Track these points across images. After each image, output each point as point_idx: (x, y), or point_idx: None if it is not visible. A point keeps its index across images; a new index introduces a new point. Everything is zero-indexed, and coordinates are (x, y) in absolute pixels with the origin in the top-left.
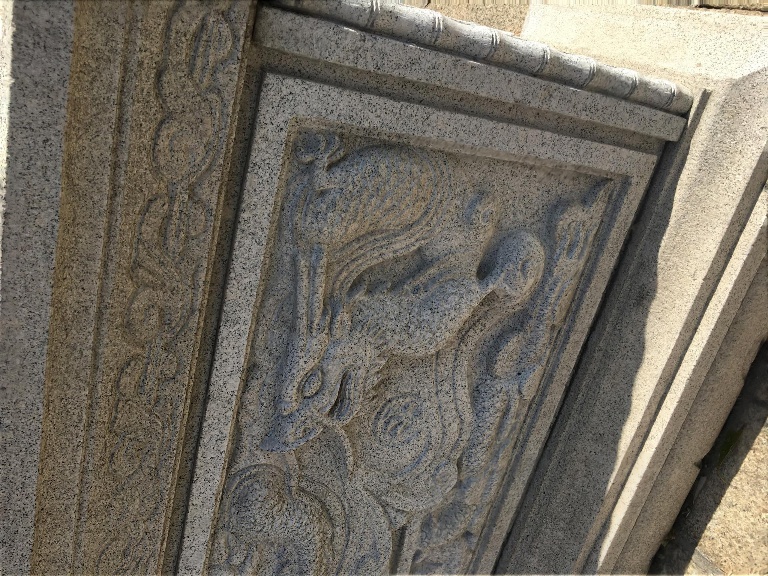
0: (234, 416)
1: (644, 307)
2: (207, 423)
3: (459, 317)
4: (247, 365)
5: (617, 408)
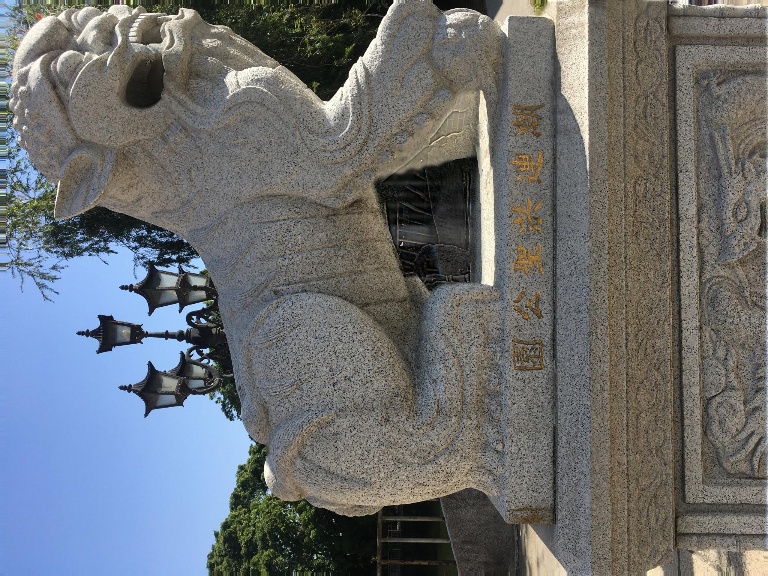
0: (696, 238)
1: None
2: (682, 236)
3: None
4: (697, 205)
5: None
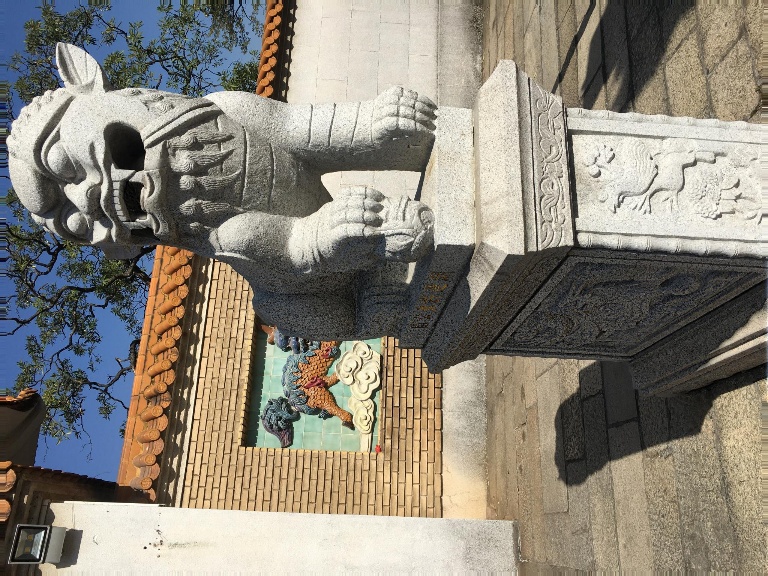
0: None
1: (753, 310)
2: (528, 305)
3: (644, 298)
4: None
5: (727, 332)
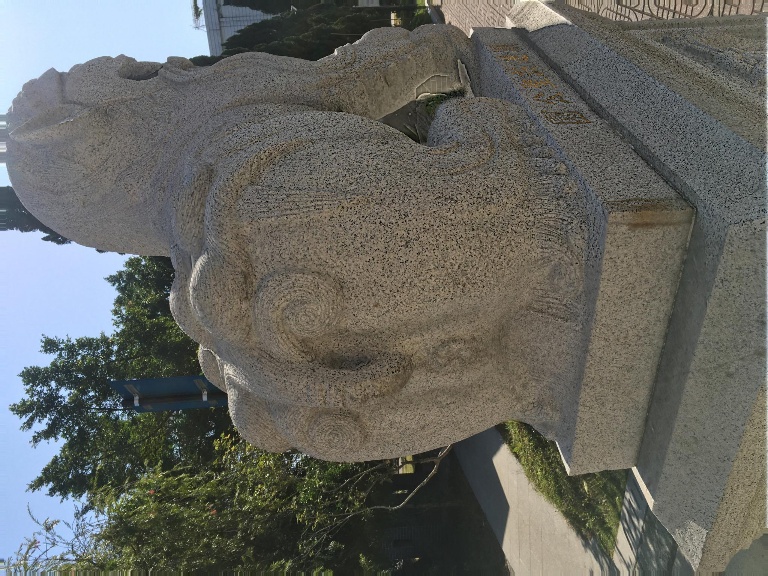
0: None
1: None
2: None
3: None
4: None
5: None
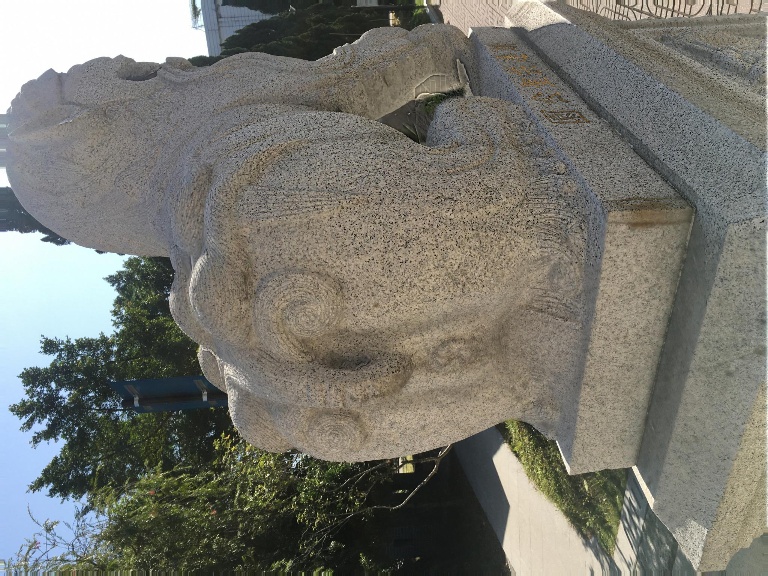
0: None
1: None
2: None
3: None
4: None
5: None
